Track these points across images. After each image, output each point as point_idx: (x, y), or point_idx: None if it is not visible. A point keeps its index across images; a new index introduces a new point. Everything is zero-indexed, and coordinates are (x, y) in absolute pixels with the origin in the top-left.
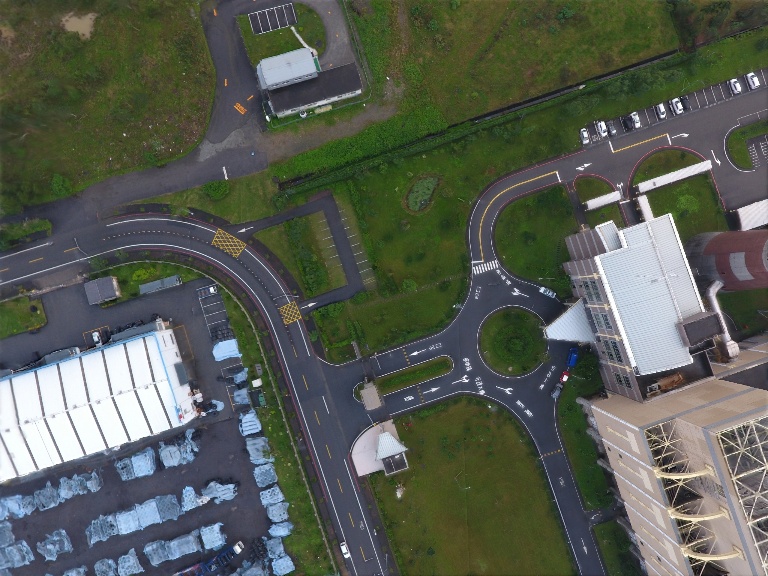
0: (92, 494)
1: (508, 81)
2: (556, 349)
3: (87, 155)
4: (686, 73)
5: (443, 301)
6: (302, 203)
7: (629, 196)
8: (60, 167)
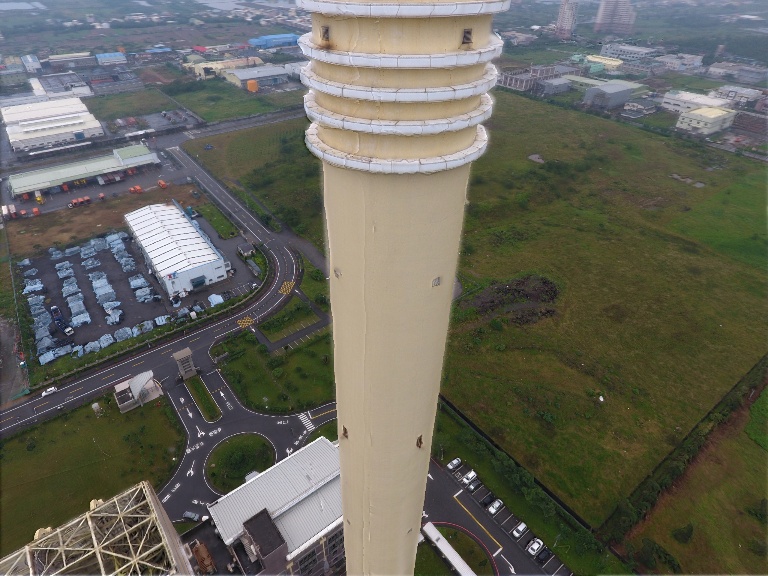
0: (121, 270)
1: (467, 393)
2: None
3: (320, 232)
4: (573, 543)
5: (270, 400)
6: (323, 310)
7: None
8: (310, 227)
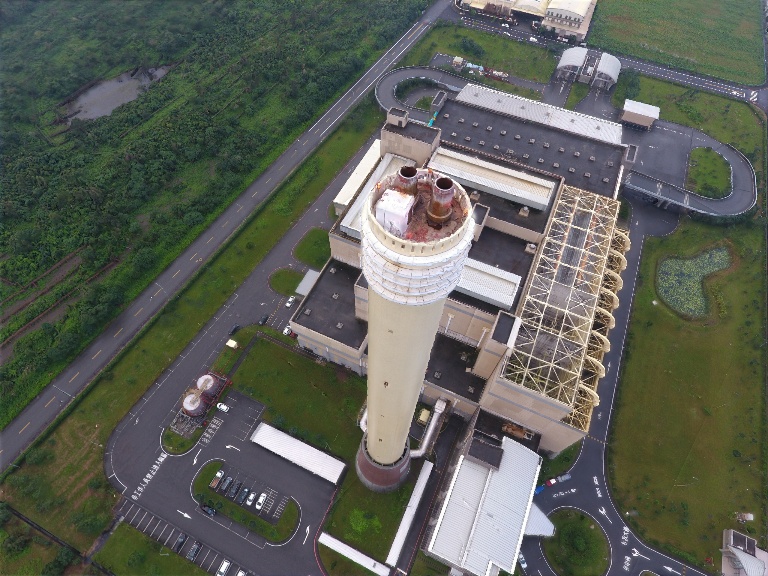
0: None
1: None
2: (543, 508)
3: None
4: None
5: None
6: None
7: (395, 573)
8: None
